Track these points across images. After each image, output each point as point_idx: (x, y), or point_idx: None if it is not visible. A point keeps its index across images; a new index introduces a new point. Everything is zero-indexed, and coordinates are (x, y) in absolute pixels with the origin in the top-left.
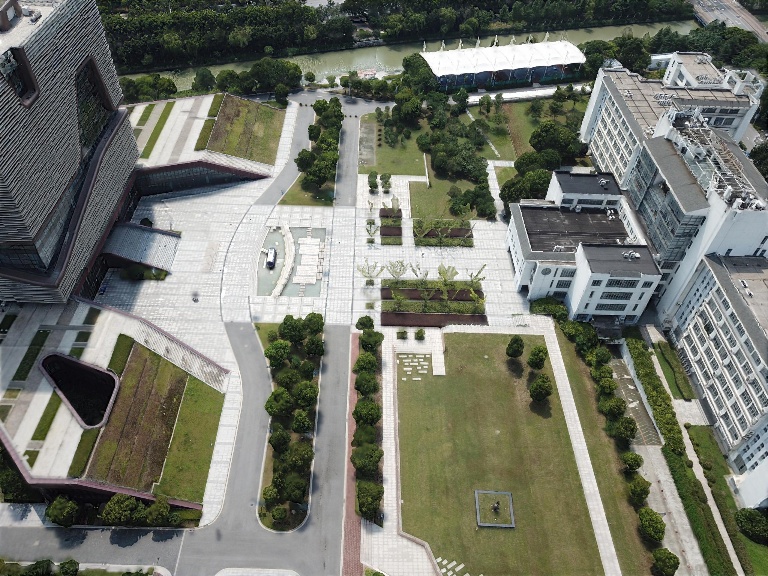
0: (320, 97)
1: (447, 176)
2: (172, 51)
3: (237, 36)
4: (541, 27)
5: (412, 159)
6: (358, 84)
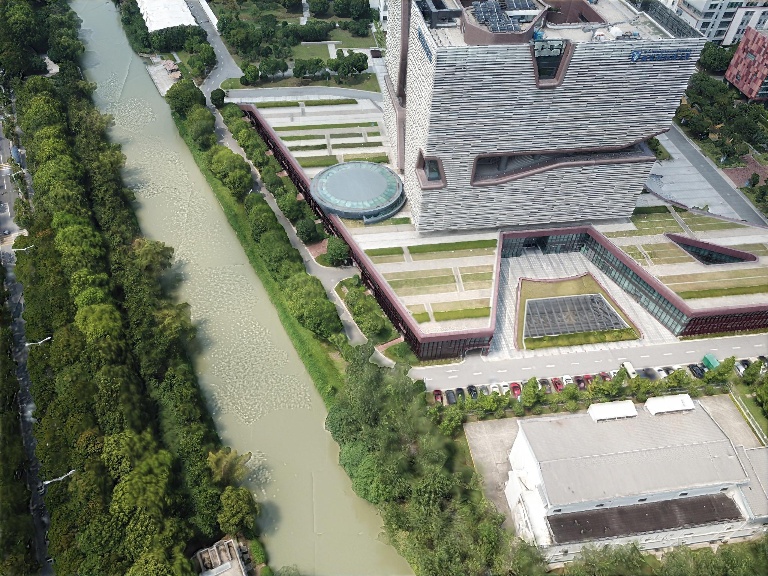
0: (210, 89)
1: (326, 38)
2: (122, 168)
3: (105, 118)
4: (64, 0)
5: (308, 49)
6: (206, 60)
